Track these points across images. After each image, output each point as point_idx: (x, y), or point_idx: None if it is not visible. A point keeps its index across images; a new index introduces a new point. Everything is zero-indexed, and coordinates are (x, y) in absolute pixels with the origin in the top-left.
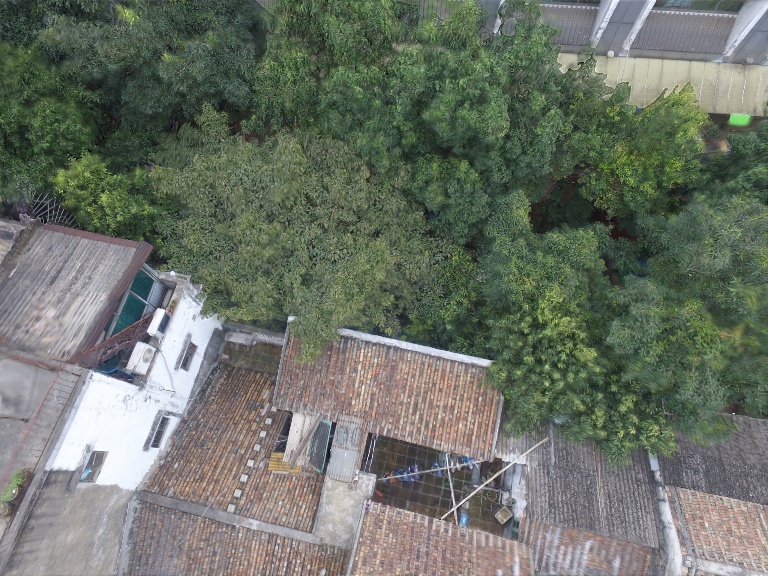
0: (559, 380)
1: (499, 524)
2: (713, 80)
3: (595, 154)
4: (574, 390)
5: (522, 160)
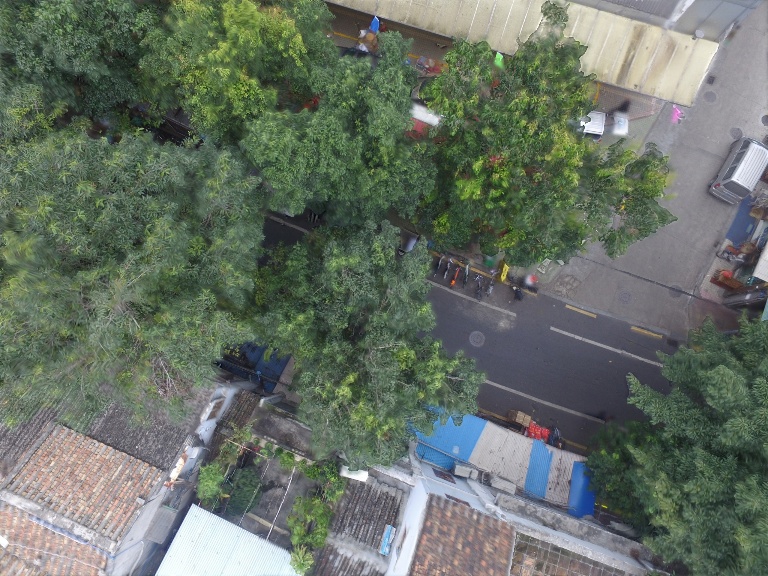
0: None
1: None
2: (490, 4)
3: (173, 60)
4: None
5: (43, 48)
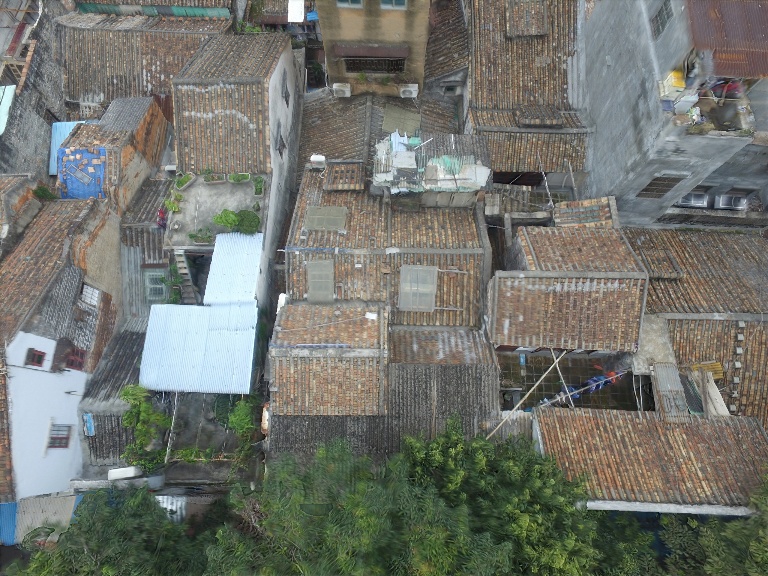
0: (542, 488)
1: None
2: None
3: None
4: (504, 486)
5: None
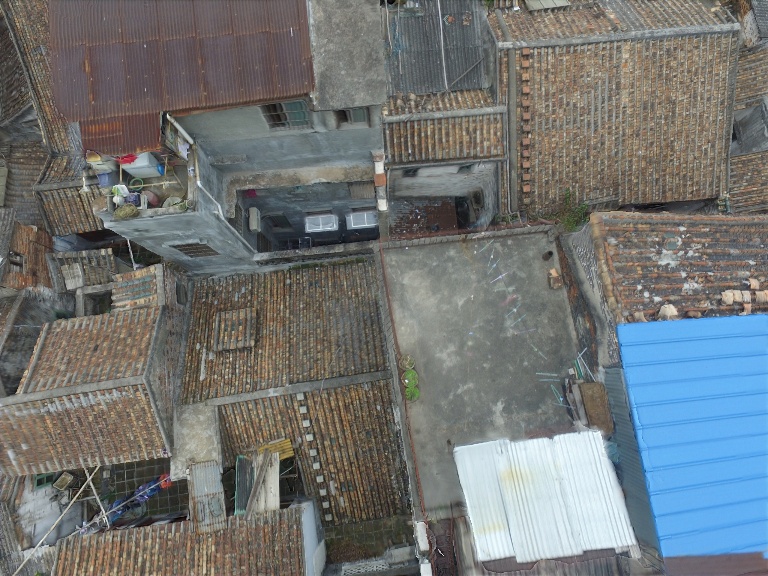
0: None
1: (69, 471)
2: None
3: None
4: None
5: None
